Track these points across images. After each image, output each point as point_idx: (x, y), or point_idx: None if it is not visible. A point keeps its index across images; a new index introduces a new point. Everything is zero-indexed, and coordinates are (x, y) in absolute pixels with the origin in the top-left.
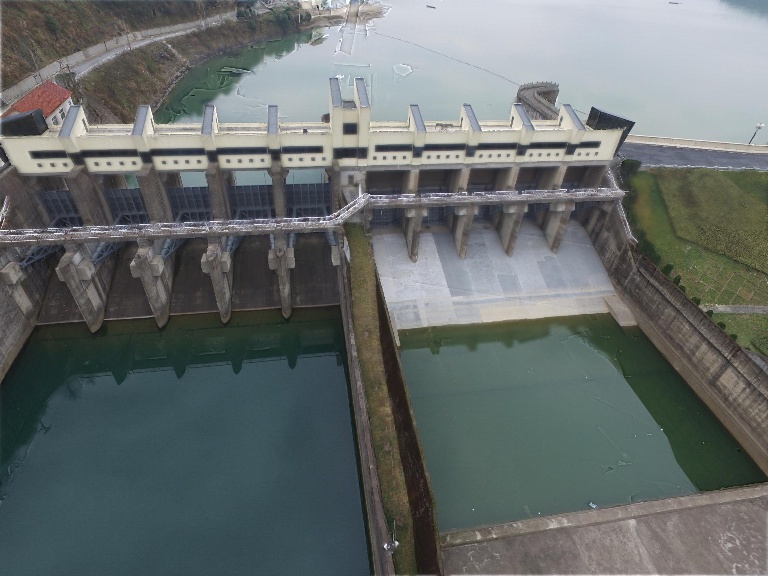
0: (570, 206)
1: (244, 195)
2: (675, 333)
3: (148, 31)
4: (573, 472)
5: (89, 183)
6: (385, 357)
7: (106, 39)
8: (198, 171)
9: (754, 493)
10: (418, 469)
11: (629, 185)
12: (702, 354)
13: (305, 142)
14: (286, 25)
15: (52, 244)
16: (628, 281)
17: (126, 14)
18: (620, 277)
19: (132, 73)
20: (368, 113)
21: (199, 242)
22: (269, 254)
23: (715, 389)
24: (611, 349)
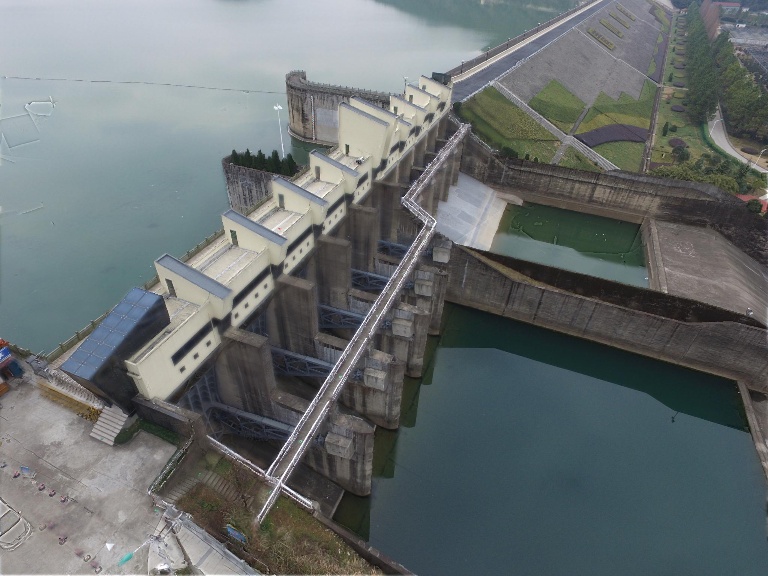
0: (461, 146)
1: None
2: (554, 189)
3: None
4: (623, 275)
5: None
6: (556, 283)
7: None
8: None
9: (655, 229)
10: (667, 301)
11: (467, 119)
12: (578, 190)
13: None
14: None
15: (320, 428)
16: (503, 178)
17: None
18: (495, 179)
19: None
20: (397, 123)
21: None
22: (424, 284)
23: (593, 203)
24: (517, 225)
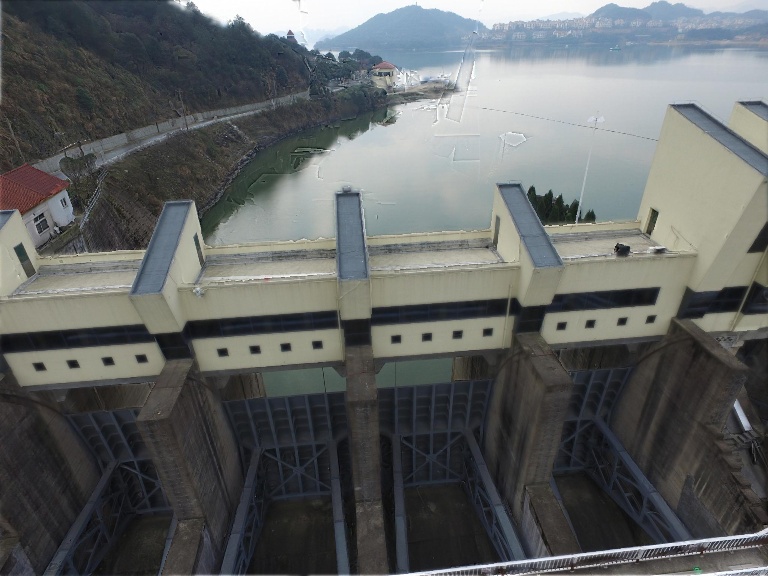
0: None
1: (414, 405)
2: None
3: (211, 113)
4: None
5: (17, 420)
6: None
7: (159, 121)
8: (312, 366)
9: None
10: None
11: None
12: None
13: (614, 280)
14: (362, 102)
15: None
16: None
17: (187, 94)
18: None
19: (186, 157)
20: None
21: (294, 506)
22: None
23: None
24: None
